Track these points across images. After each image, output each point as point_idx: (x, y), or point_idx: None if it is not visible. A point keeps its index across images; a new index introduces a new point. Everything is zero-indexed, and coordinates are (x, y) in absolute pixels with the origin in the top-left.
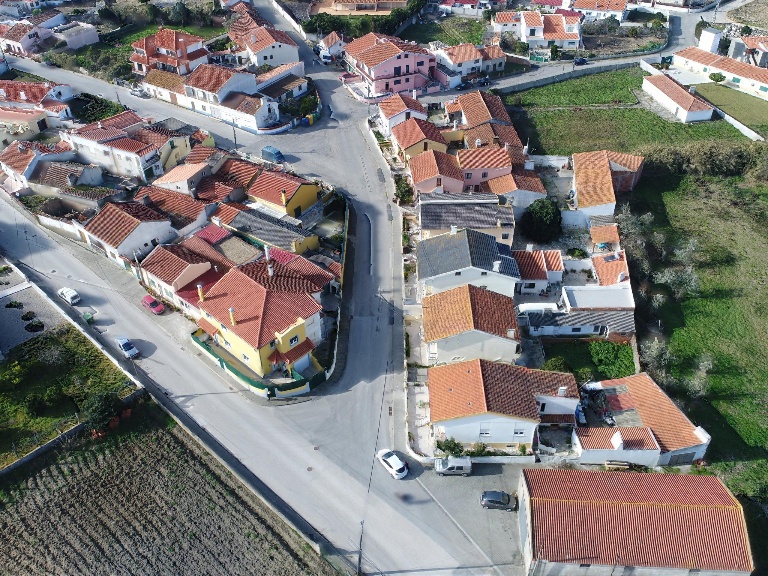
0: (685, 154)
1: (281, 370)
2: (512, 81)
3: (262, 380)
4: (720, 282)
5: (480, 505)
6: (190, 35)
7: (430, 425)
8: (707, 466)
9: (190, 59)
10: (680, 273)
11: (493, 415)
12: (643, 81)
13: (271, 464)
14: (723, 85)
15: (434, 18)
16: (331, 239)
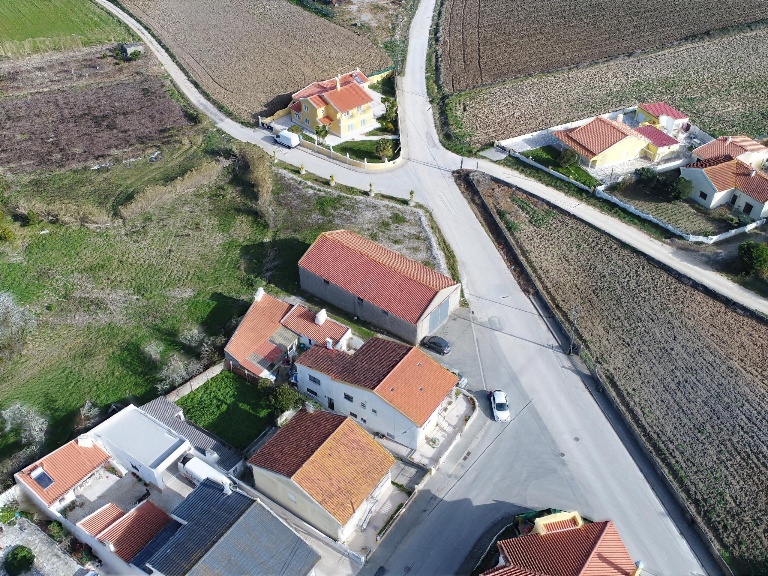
0: None
1: None
2: None
3: None
4: None
5: None
6: None
7: None
8: None
9: None
10: (18, 420)
11: None
12: None
13: (614, 461)
14: None
15: None
16: None
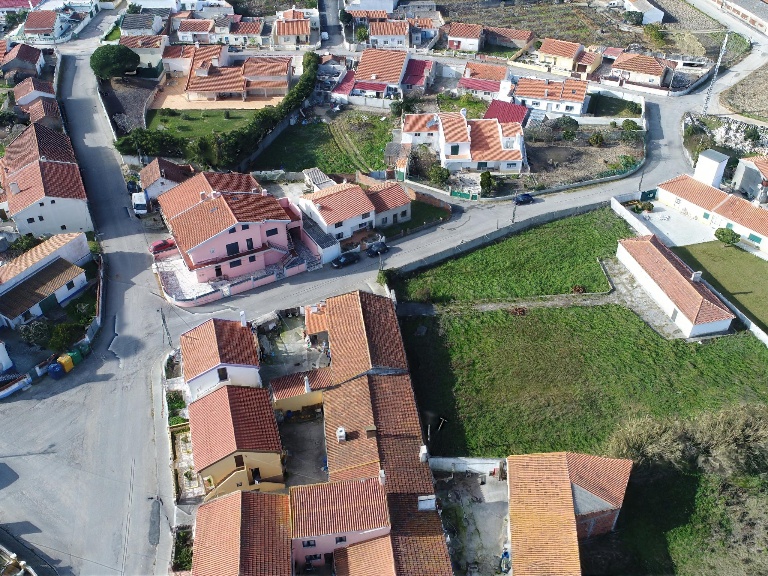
0: (701, 440)
1: None
2: (421, 243)
3: None
4: None
5: None
6: None
7: None
8: None
9: None
10: None
11: None
12: (618, 246)
13: None
14: (735, 246)
15: (323, 113)
16: None
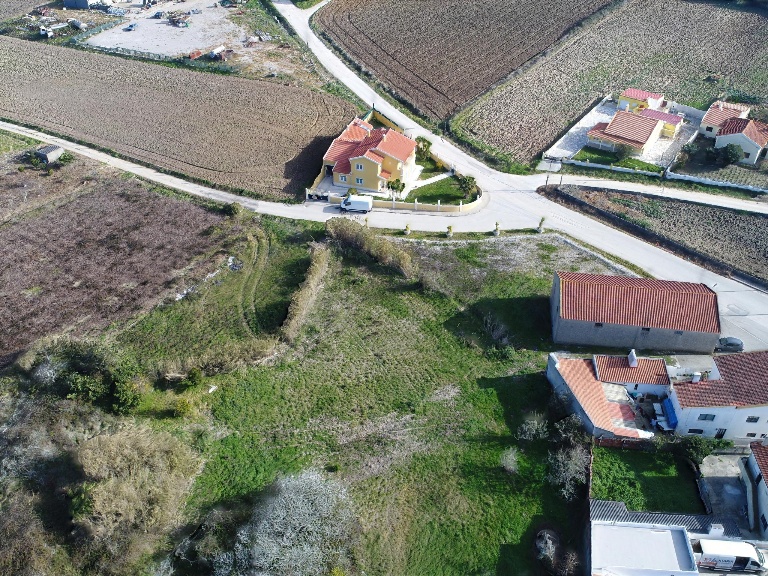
0: None
1: None
2: None
3: None
4: None
5: None
6: None
7: None
8: None
9: None
10: None
11: None
12: None
13: None
14: None
15: None
16: None
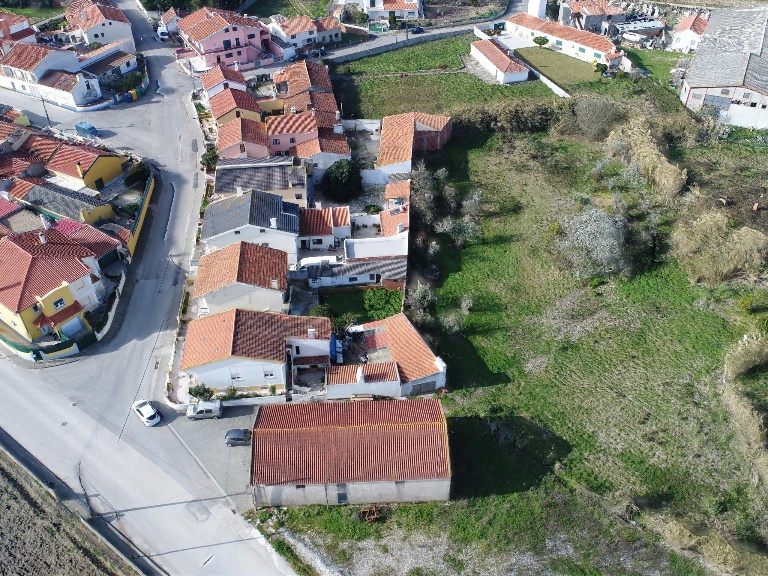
0: (492, 113)
1: (52, 334)
2: (347, 51)
3: (28, 344)
4: (503, 229)
5: (224, 443)
6: (14, 15)
7: (190, 375)
8: (449, 393)
9: (14, 39)
10: (458, 222)
11: (238, 359)
12: None
13: (26, 422)
14: (547, 48)
15: None
16: (125, 208)
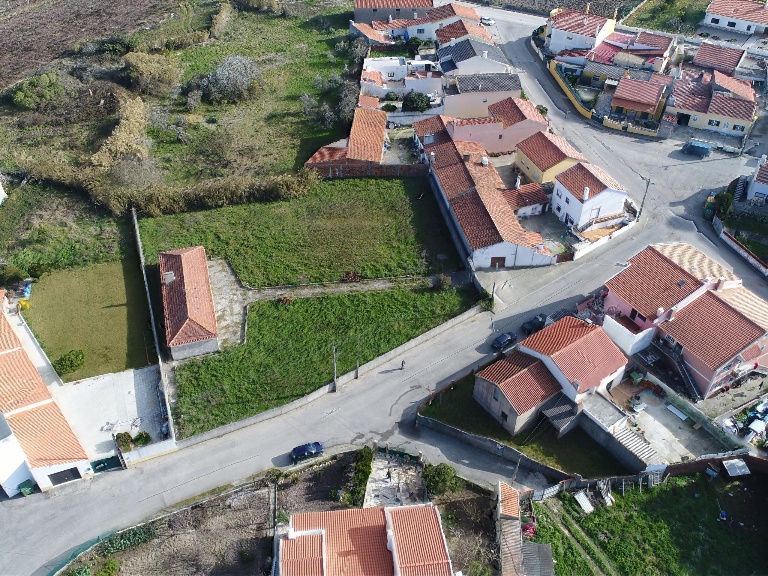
0: None
1: None
2: (455, 360)
3: None
4: (289, 105)
5: None
6: None
7: None
8: None
9: None
10: None
11: None
12: None
13: None
14: None
15: None
16: None
